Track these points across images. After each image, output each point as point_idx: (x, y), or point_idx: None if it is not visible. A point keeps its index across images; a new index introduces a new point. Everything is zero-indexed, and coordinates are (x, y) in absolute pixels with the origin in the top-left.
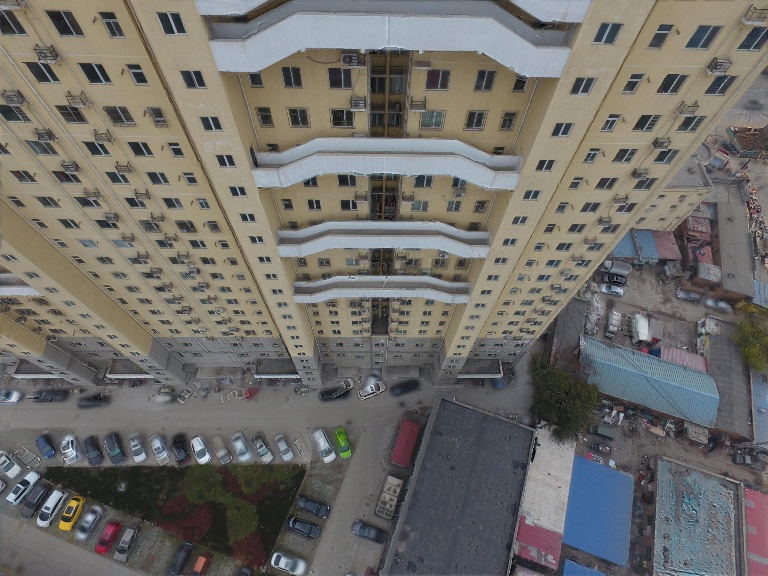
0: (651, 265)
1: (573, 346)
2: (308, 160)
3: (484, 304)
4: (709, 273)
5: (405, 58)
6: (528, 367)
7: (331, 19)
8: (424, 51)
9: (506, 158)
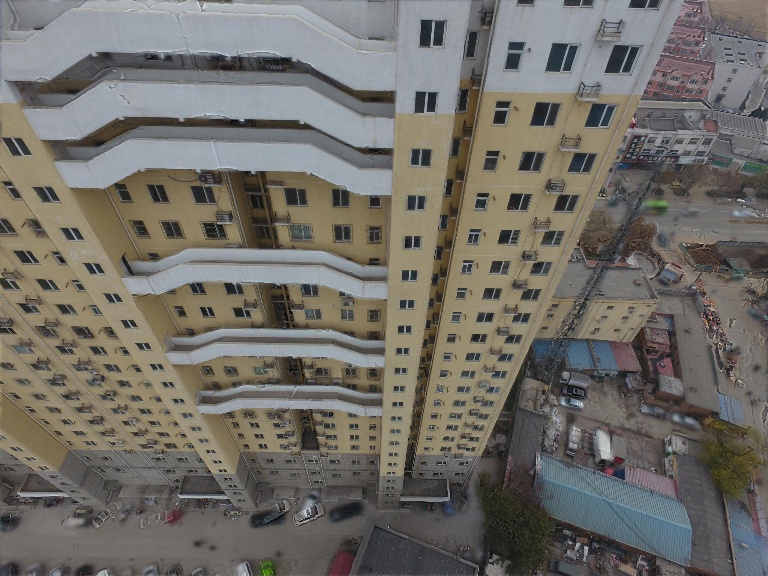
0: (612, 377)
1: (529, 465)
2: (174, 269)
3: (400, 417)
4: (670, 386)
5: (264, 178)
6: (482, 489)
7: (161, 144)
8: (256, 171)
9: (378, 269)
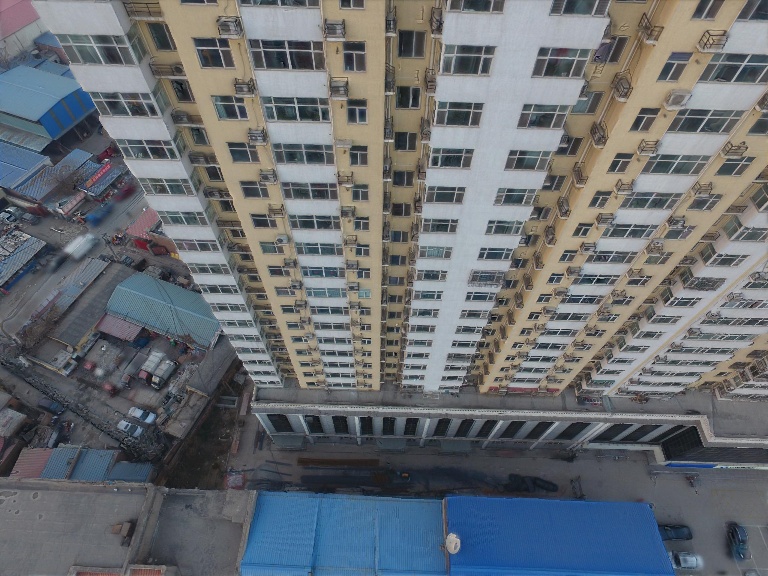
0: None
1: (225, 339)
2: None
3: None
4: (10, 418)
5: None
6: None
7: None
8: None
9: None
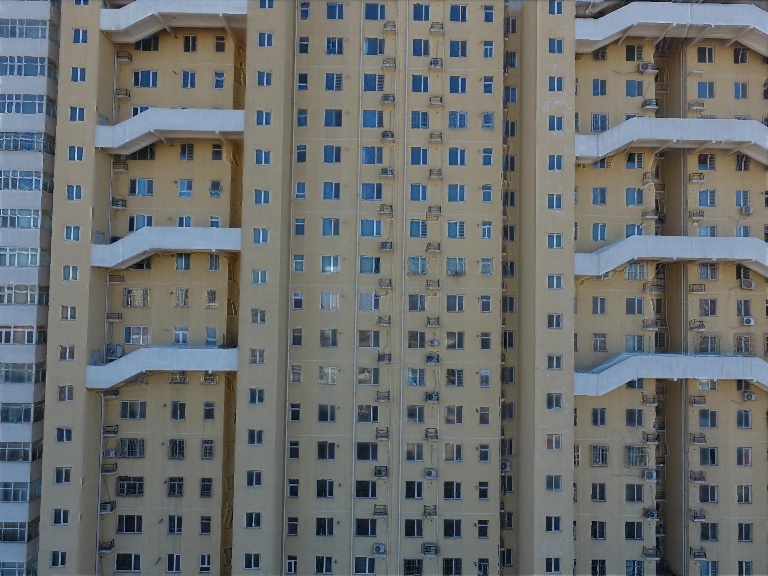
0: None
1: None
2: (626, 122)
3: None
4: None
5: (676, 82)
6: None
7: (655, 4)
8: (715, 26)
9: None
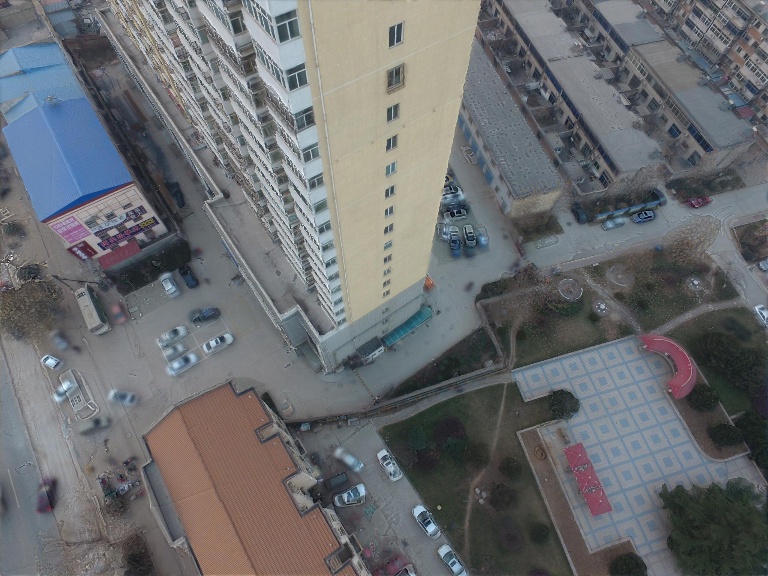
0: None
1: None
2: None
3: None
4: None
5: None
6: None
7: None
8: None
9: None
